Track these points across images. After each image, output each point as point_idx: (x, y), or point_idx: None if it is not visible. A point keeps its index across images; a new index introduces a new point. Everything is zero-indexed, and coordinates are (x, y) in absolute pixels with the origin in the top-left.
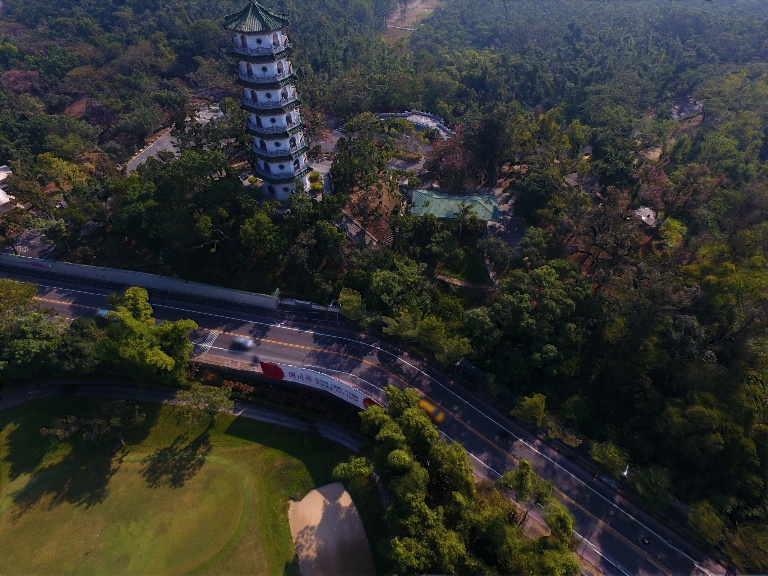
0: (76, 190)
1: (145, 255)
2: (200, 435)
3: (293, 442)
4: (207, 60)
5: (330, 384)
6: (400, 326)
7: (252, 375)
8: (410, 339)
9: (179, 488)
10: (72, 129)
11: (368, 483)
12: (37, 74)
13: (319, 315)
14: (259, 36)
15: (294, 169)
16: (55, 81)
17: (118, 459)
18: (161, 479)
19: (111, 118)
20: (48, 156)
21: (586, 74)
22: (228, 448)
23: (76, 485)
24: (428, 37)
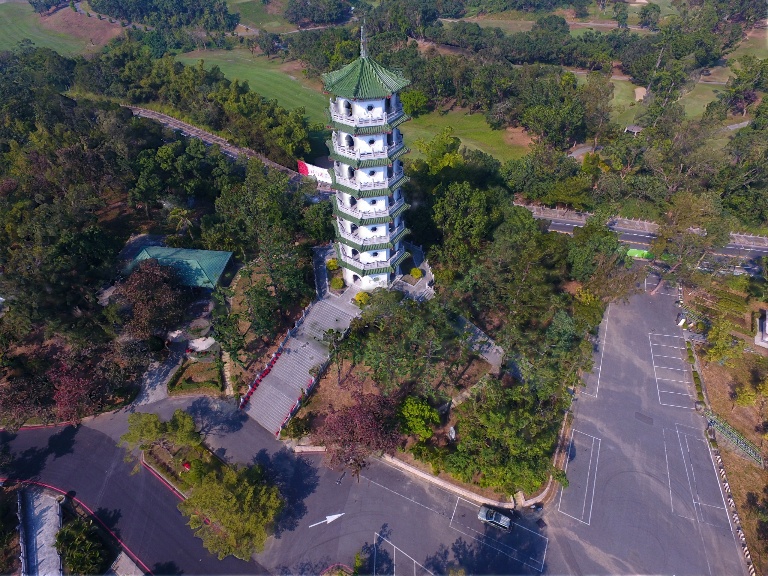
0: None
1: None
2: None
3: None
4: None
5: None
6: None
7: None
8: None
9: None
10: None
11: None
12: None
13: None
14: None
15: None
16: None
17: None
18: None
19: None
20: None
21: None
22: None
23: None
24: None
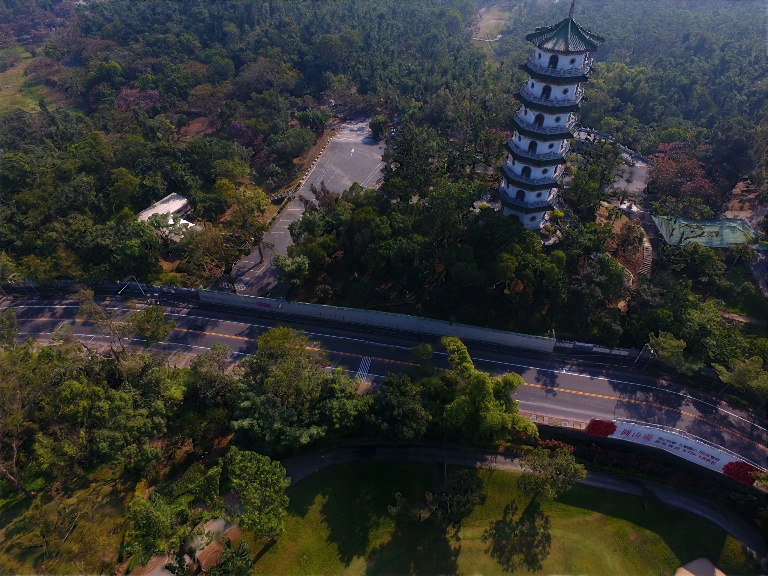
0: (307, 223)
1: (387, 293)
2: (529, 504)
3: (634, 510)
4: (335, 76)
5: (678, 444)
6: (740, 375)
7: (566, 431)
8: (723, 386)
9: (539, 571)
10: (231, 152)
11: (747, 560)
12: (157, 93)
13: (602, 358)
14: (575, 56)
15: (547, 197)
16: (173, 100)
17: (453, 536)
18: (514, 560)
19: (254, 139)
20: (227, 183)
21: (766, 87)
22: (567, 519)
23: (422, 570)
24: (517, 48)
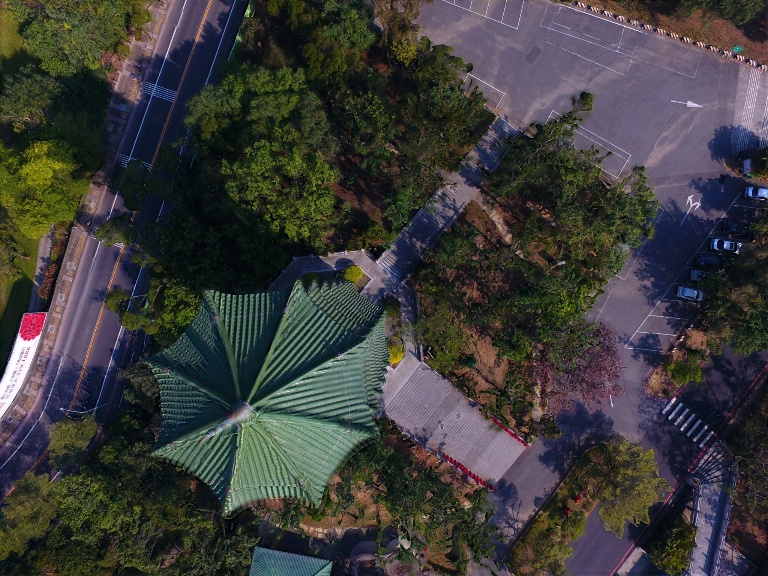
0: None
1: None
2: None
3: (7, 340)
4: None
5: None
6: None
7: None
8: None
9: None
10: None
11: None
12: None
13: None
14: None
15: None
16: None
17: None
18: None
19: None
20: None
21: None
22: None
23: None
24: None
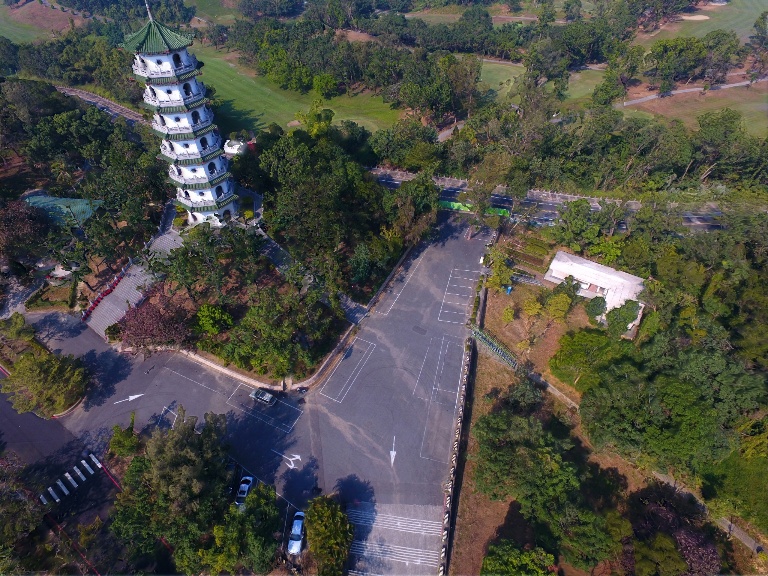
0: None
1: None
2: None
3: None
4: None
5: None
6: None
7: None
8: None
9: None
10: None
11: None
12: None
13: None
14: None
15: None
16: None
17: None
18: None
19: None
20: None
21: None
22: None
23: None
24: None
